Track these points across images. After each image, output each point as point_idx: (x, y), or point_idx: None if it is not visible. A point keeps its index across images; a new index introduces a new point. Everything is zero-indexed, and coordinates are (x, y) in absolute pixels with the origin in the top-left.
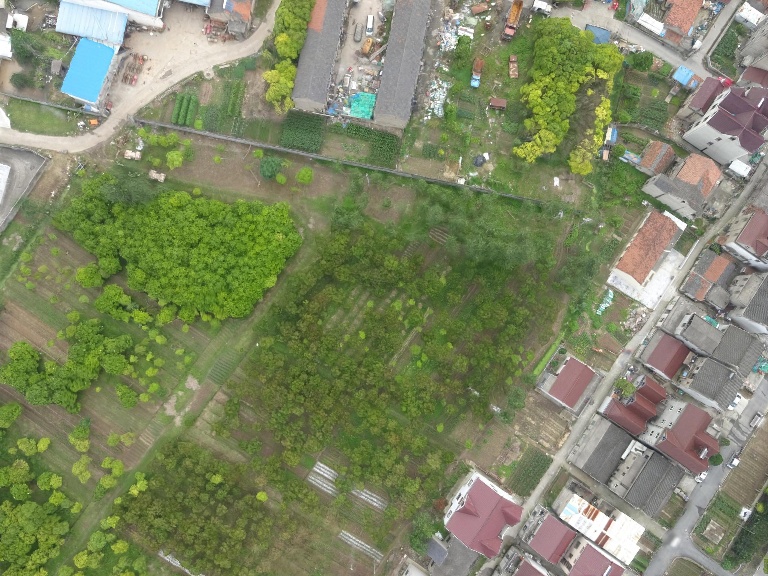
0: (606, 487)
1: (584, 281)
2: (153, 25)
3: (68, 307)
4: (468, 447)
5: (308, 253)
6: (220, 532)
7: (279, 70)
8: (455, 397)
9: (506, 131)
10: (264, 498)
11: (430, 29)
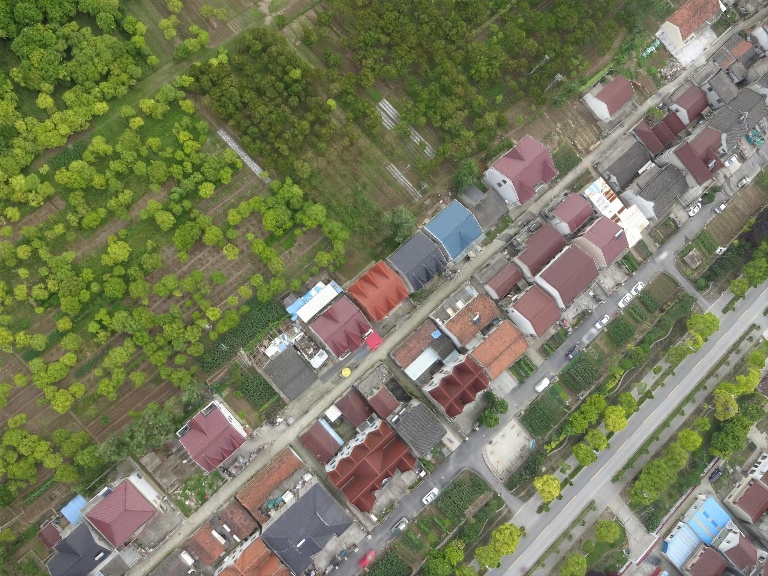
0: (619, 197)
1: (649, 3)
2: None
3: None
4: (519, 120)
5: None
6: (286, 122)
7: None
8: (517, 77)
9: None
10: (333, 105)
11: None
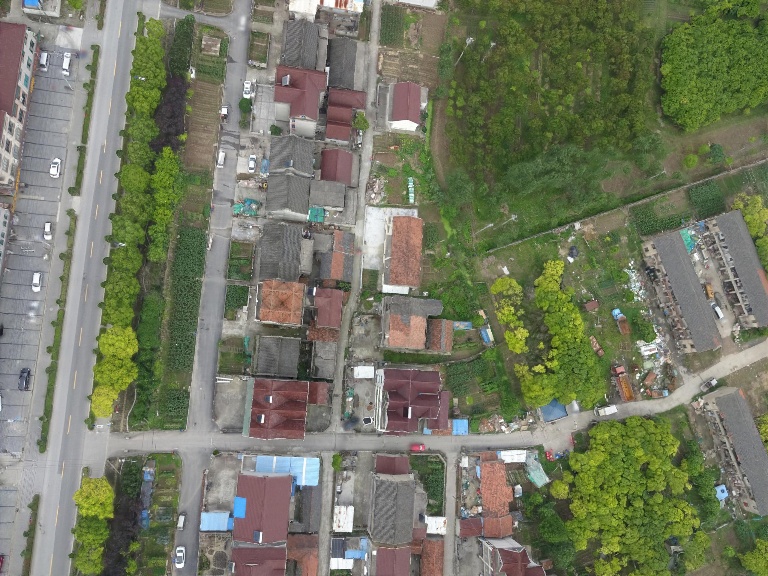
0: None
1: None
2: None
3: None
4: None
5: None
6: None
7: (763, 223)
8: None
9: None
10: None
11: (672, 338)
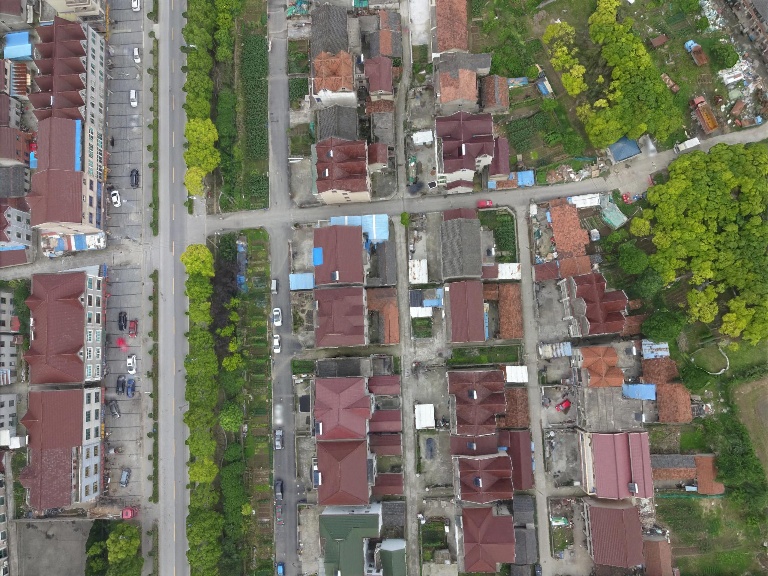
0: None
1: None
2: None
3: None
4: None
5: None
6: None
7: None
8: None
9: None
10: None
11: (763, 64)
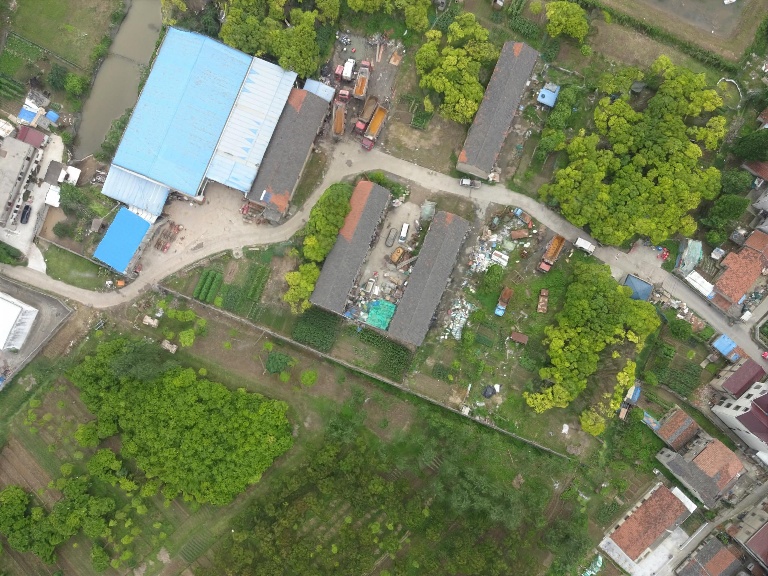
0: None
1: (568, 558)
2: (194, 197)
3: (65, 455)
4: None
5: (299, 451)
6: None
7: (302, 272)
8: None
9: (522, 366)
10: None
11: (465, 246)
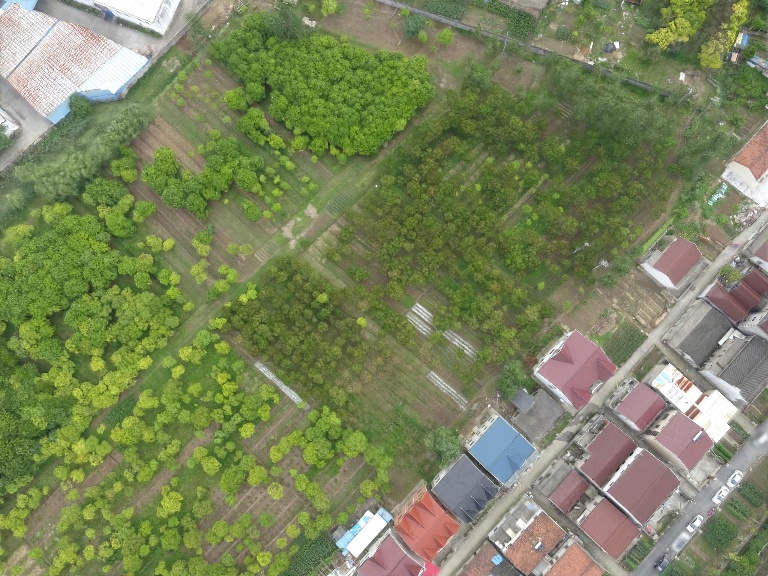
0: (698, 372)
1: (705, 157)
2: None
3: (210, 128)
4: (566, 307)
5: (436, 110)
6: (317, 349)
7: None
8: (559, 259)
9: (639, 24)
10: (364, 324)
11: None
